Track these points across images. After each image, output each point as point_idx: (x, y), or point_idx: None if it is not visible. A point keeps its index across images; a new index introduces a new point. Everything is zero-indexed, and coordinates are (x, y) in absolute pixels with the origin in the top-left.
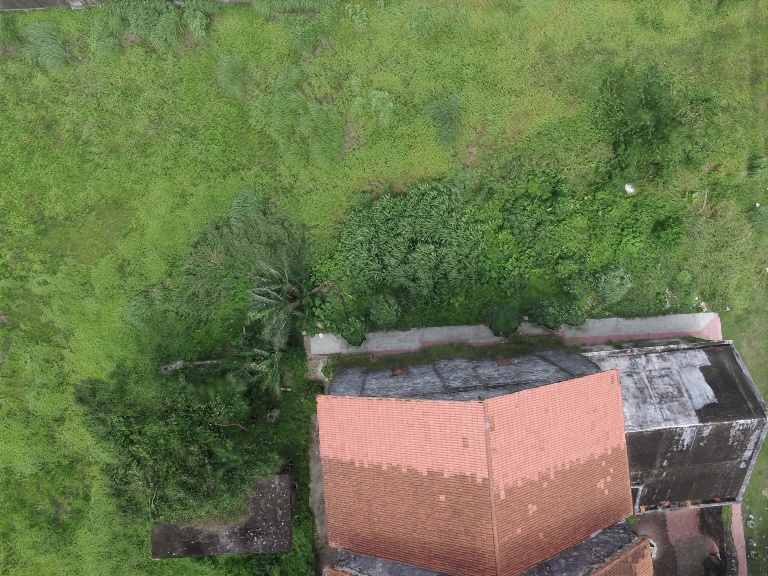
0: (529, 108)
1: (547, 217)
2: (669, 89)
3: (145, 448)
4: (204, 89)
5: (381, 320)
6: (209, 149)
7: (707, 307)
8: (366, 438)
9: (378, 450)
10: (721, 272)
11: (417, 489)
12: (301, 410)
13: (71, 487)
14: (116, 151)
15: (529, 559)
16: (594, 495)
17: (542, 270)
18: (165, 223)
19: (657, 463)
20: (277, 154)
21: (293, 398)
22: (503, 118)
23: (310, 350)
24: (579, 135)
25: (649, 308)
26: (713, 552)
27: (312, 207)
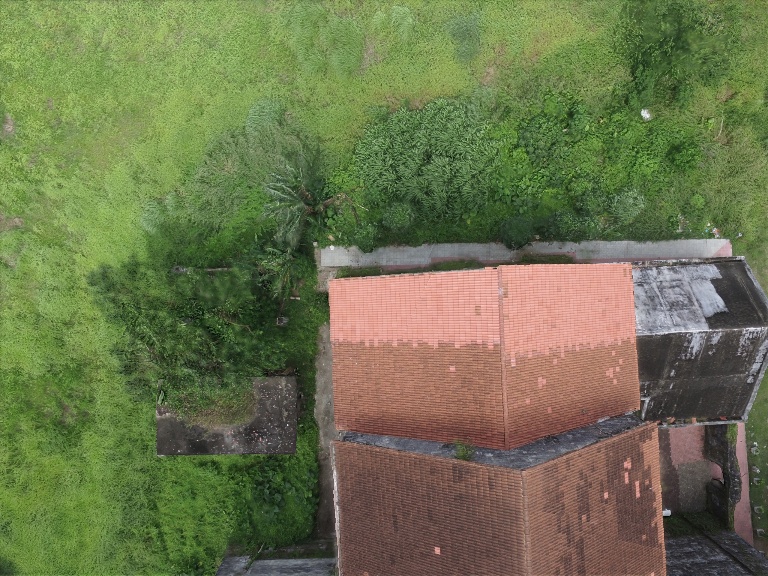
0: (548, 30)
1: (562, 138)
2: (689, 16)
3: (155, 335)
4: (224, 0)
5: (394, 223)
6: (227, 60)
7: (719, 233)
8: (377, 317)
9: (389, 328)
10: (734, 197)
11: (427, 362)
12: (309, 320)
13: (78, 390)
14: (134, 59)
15: (537, 431)
16: (603, 382)
17: (555, 190)
18: (181, 131)
19: (665, 373)
20: (295, 67)
21: (302, 307)
22: (521, 38)
23: (320, 262)
24: (597, 58)
25: (661, 231)
26: (716, 477)
27: (328, 120)
